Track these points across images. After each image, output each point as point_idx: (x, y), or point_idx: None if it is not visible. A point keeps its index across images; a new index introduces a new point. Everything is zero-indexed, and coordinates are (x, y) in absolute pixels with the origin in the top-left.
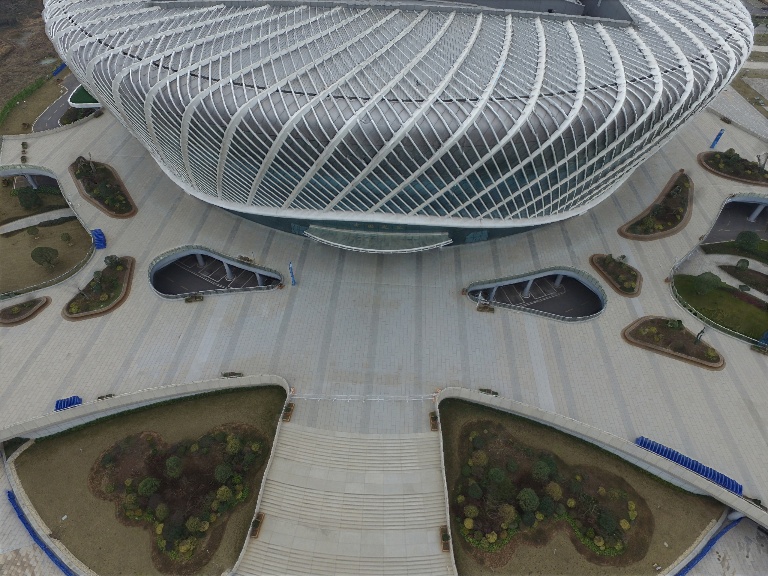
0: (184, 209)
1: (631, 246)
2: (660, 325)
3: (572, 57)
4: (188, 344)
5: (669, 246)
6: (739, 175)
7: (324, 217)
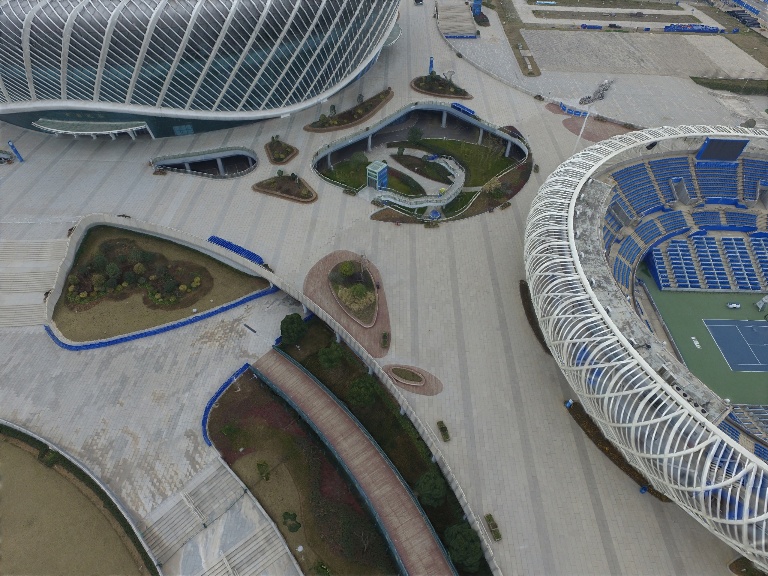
0: None
1: (306, 136)
2: (282, 178)
3: None
4: None
5: (337, 135)
6: (432, 90)
7: (34, 106)
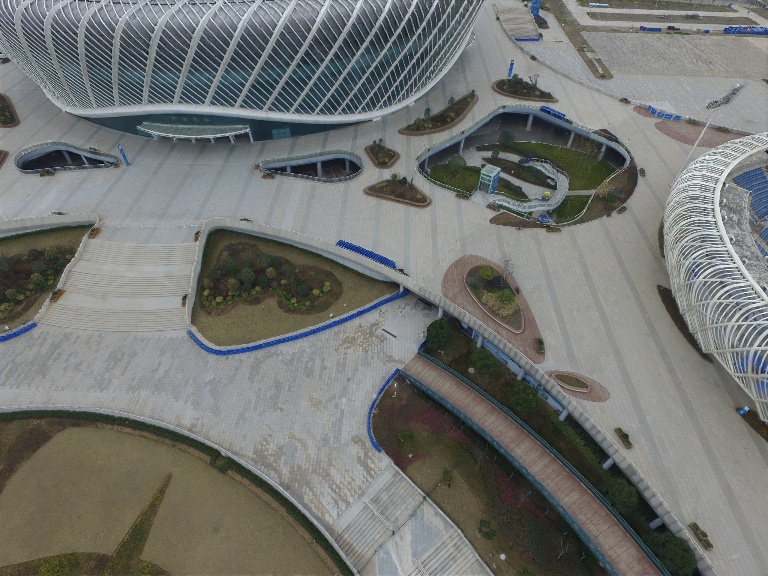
0: (58, 121)
1: (403, 139)
2: (393, 182)
3: None
4: (34, 199)
5: (433, 139)
6: (517, 93)
7: (143, 109)
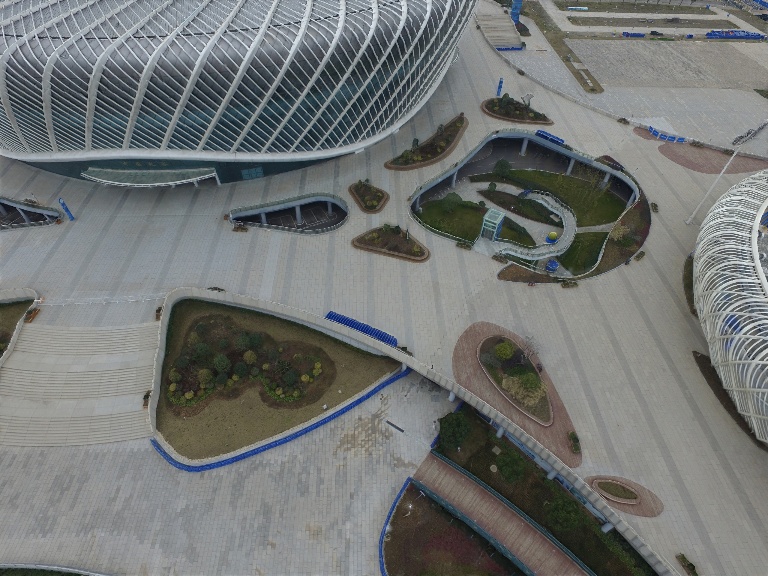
0: None
1: (391, 175)
2: (384, 232)
3: (270, 2)
4: None
5: (424, 173)
6: (509, 115)
7: (87, 156)
